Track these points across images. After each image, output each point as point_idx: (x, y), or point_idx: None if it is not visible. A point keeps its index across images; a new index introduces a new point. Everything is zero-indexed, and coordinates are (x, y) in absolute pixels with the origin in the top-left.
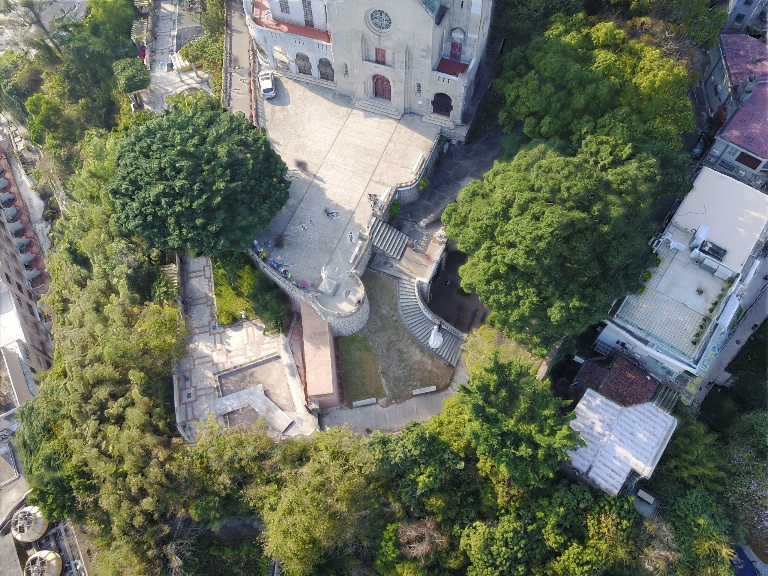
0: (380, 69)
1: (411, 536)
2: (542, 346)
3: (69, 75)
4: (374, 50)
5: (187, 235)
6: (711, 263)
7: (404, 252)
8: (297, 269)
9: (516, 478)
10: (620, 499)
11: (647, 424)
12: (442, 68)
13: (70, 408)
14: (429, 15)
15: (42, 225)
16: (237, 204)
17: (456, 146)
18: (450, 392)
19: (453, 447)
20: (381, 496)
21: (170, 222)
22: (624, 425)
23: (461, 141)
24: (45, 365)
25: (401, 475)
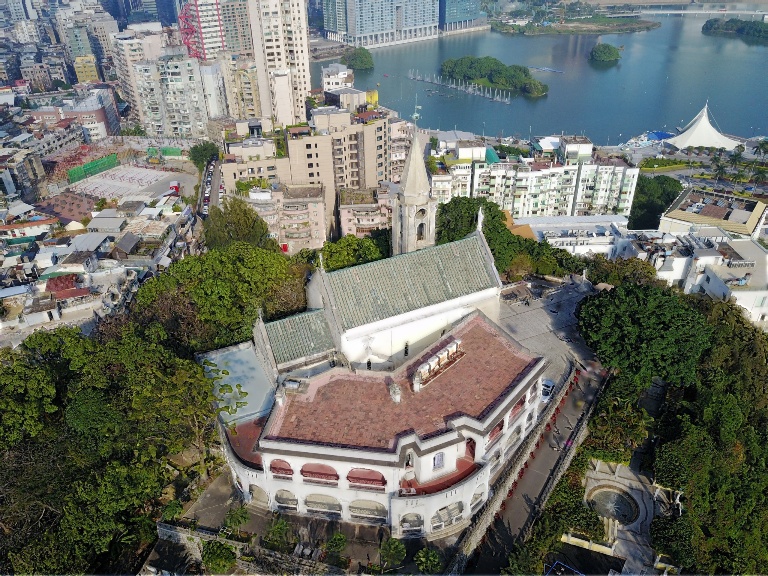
0: None
1: (592, 256)
2: None
3: None
4: None
5: None
6: None
7: None
8: None
9: None
10: None
11: None
12: None
13: None
14: None
15: None
16: None
17: None
18: None
19: None
20: None
21: None
22: None
23: None
24: None
25: None
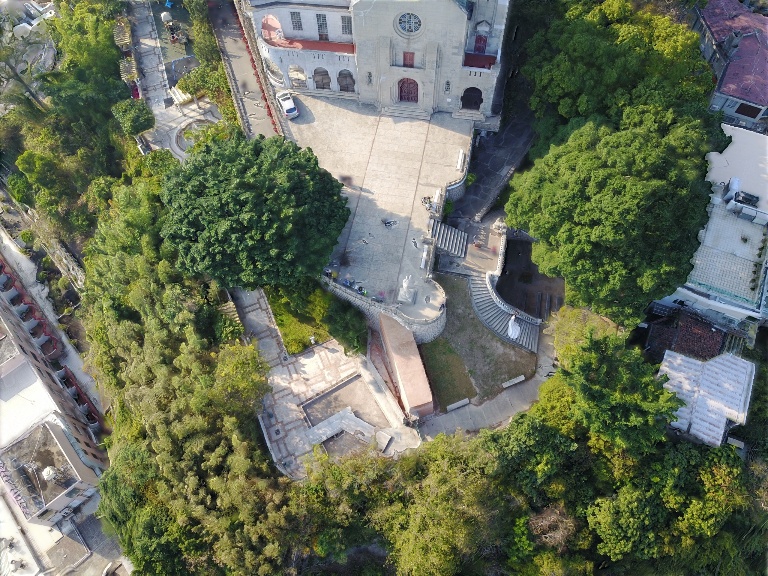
0: (409, 72)
1: (544, 526)
2: (634, 316)
3: (59, 126)
4: (402, 54)
5: (262, 268)
6: (749, 211)
7: (466, 249)
8: (370, 284)
9: (629, 449)
10: (724, 449)
11: (729, 373)
12: (469, 63)
13: (163, 469)
14: (463, 11)
15: (38, 288)
16: (305, 228)
17: (485, 138)
18: (538, 378)
19: (563, 431)
20: (502, 493)
21: (242, 258)
22: (709, 378)
23: (489, 132)
24: (83, 433)
25: (517, 469)
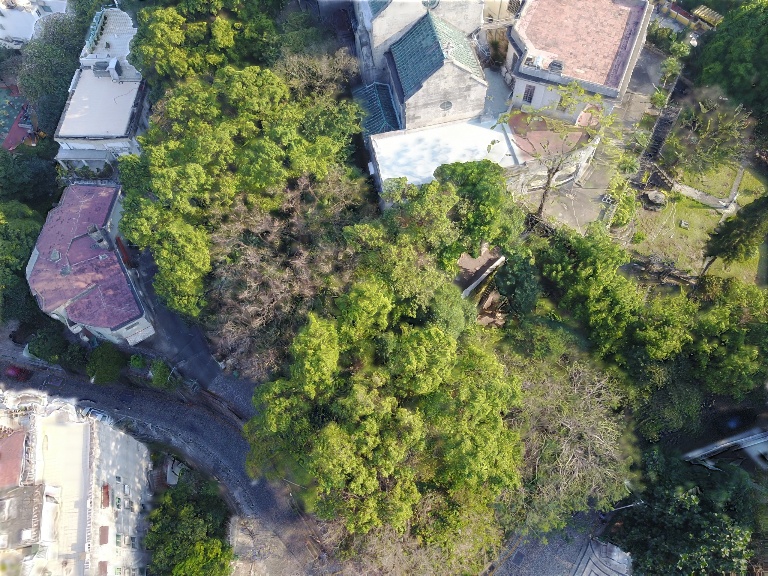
0: None
1: None
2: None
3: None
4: None
5: None
6: (102, 56)
7: None
8: None
9: None
10: None
11: None
12: None
13: None
14: None
15: None
16: None
17: None
18: None
19: None
20: None
21: None
22: None
23: None
24: None
25: None
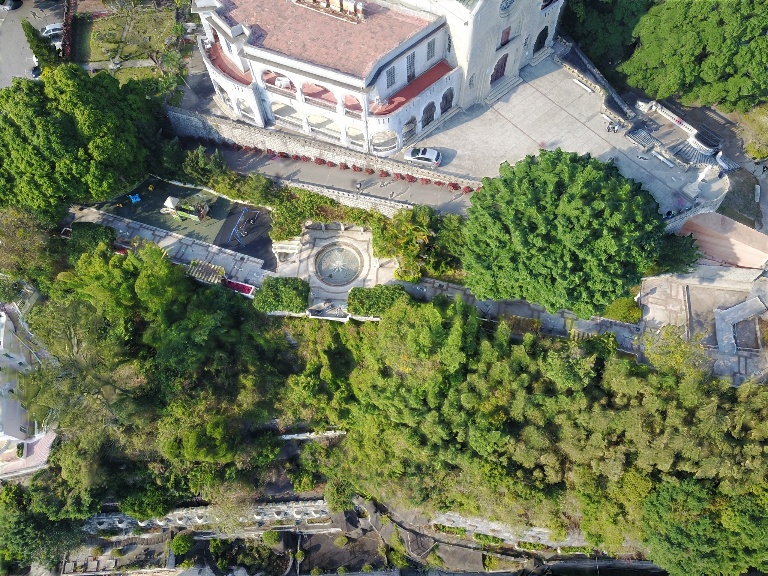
0: (509, 47)
1: None
2: None
3: None
4: (501, 35)
5: None
6: None
7: None
8: (662, 207)
9: None
10: None
11: None
12: None
13: None
14: None
15: None
16: None
17: None
18: (761, 179)
19: None
20: None
21: (635, 254)
22: None
23: None
24: None
25: None
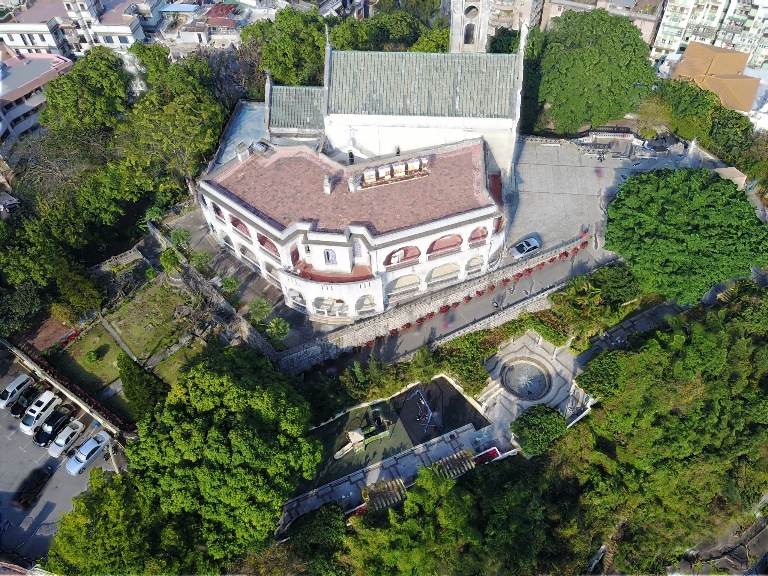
0: None
1: None
2: None
3: None
4: None
5: None
6: None
7: None
8: None
9: None
10: None
11: None
12: None
13: None
14: None
15: None
16: None
17: None
18: None
19: None
20: None
21: None
22: None
23: None
24: None
25: None
